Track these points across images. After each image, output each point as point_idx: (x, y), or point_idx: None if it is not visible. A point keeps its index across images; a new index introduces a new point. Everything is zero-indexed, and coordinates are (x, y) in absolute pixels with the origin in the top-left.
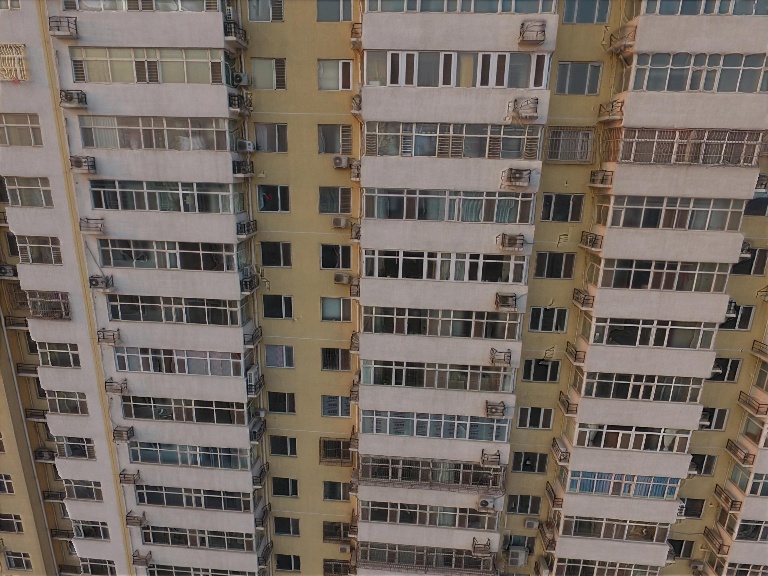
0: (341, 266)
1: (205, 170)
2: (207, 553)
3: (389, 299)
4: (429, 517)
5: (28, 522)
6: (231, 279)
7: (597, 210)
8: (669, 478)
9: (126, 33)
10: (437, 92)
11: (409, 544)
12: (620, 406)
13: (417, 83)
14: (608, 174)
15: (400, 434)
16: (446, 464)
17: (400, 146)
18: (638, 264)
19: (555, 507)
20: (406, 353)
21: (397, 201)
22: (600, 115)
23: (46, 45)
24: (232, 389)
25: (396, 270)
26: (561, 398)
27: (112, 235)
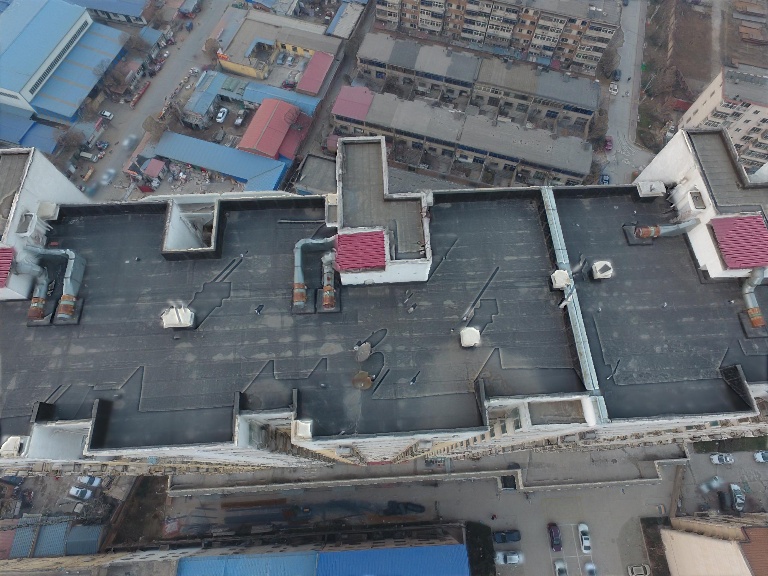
0: None
1: None
2: None
3: None
4: None
5: None
6: None
7: None
8: None
9: None
10: None
11: None
12: None
13: None
14: None
15: None
16: None
17: None
18: None
19: None
20: None
21: None
22: None
23: None
24: None
25: None
26: None
27: None
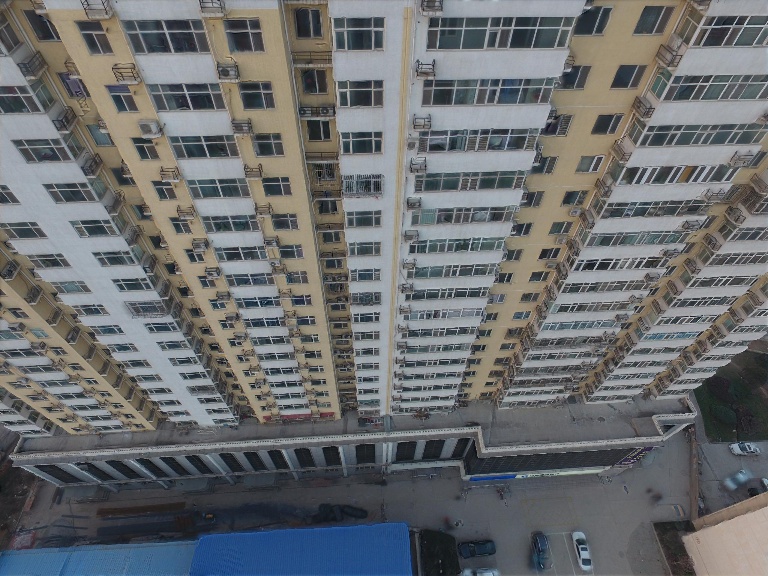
0: (551, 257)
1: (492, 232)
2: (435, 381)
3: (583, 280)
4: (563, 356)
5: (331, 381)
6: (490, 279)
7: (722, 226)
8: (696, 331)
9: (462, 165)
10: (662, 187)
11: (548, 366)
12: (688, 310)
13: (651, 182)
14: (742, 218)
15: (562, 329)
16: (581, 337)
17: (624, 213)
18: (733, 255)
19: (631, 346)
20: (582, 300)
21: (609, 238)
22: (752, 179)
23: (399, 174)
24: (473, 322)
25: (593, 267)
26: (654, 303)
27: (419, 266)
